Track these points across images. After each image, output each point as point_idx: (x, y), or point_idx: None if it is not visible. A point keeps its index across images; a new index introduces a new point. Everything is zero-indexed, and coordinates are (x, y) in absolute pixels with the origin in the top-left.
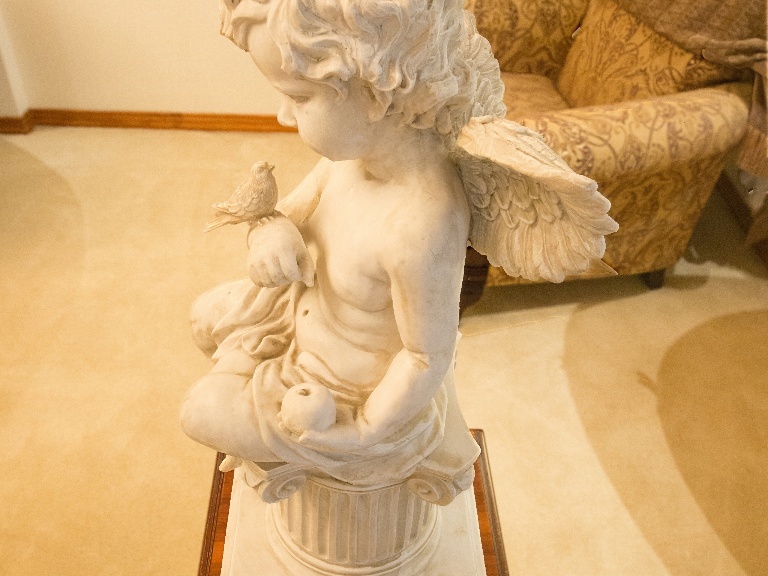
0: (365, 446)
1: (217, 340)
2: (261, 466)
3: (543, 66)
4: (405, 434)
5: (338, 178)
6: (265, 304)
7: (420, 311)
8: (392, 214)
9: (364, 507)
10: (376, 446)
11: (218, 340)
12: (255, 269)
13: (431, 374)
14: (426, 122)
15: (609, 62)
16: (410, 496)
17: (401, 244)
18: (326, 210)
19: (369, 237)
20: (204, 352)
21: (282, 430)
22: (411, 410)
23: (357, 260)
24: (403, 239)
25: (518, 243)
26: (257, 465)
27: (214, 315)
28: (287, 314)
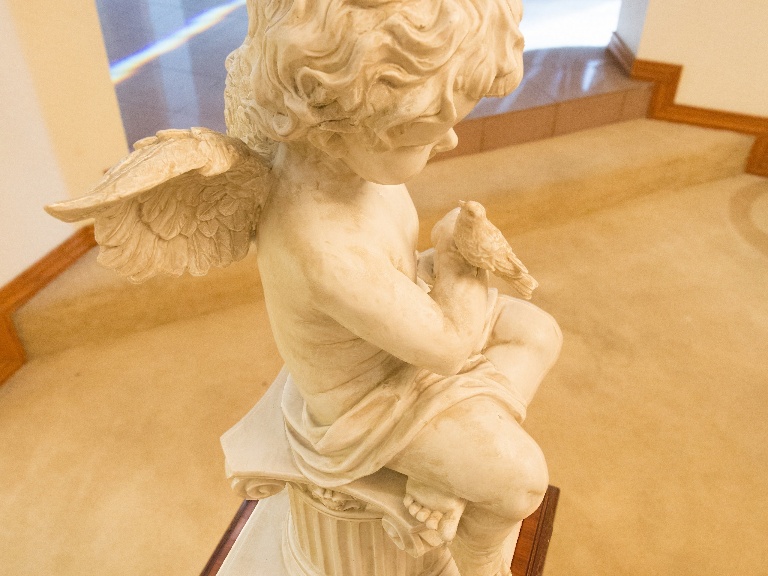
0: None
1: None
2: None
3: None
4: None
5: (383, 220)
6: None
7: None
8: None
9: None
10: None
11: None
12: None
13: None
14: None
15: None
16: None
17: None
18: None
19: None
20: None
21: None
22: None
23: None
24: None
25: None
26: None
27: None
28: None
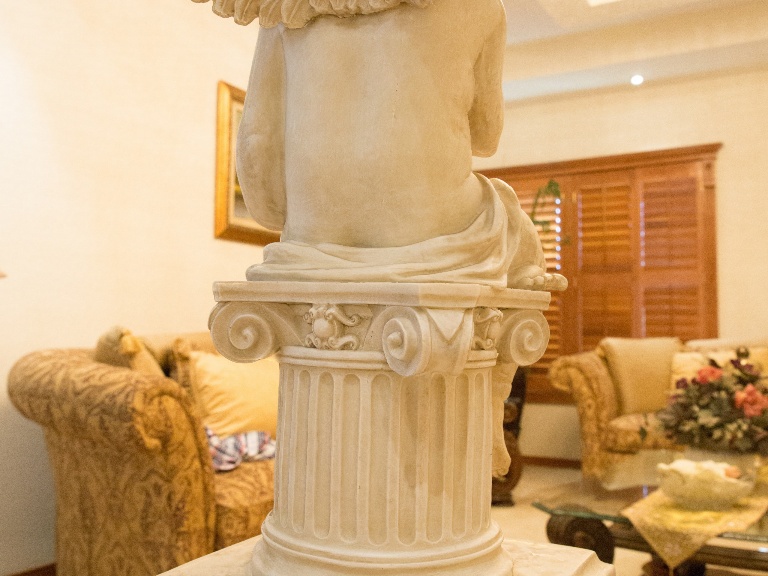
0: None
1: None
2: None
3: None
4: None
5: None
6: None
7: None
8: None
9: None
10: None
11: None
12: None
13: None
14: None
15: None
16: None
17: None
18: None
19: None
20: None
21: None
22: None
23: None
24: None
25: None
26: None
27: None
28: None
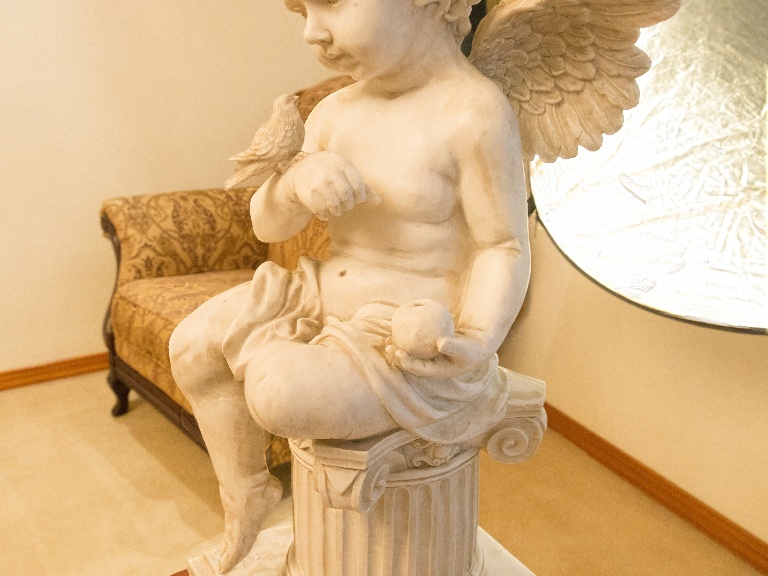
0: (488, 355)
1: (229, 353)
2: (357, 449)
3: (249, 261)
4: (485, 372)
5: (350, 117)
6: (279, 293)
7: (505, 189)
8: (451, 100)
9: (442, 503)
10: (469, 386)
11: (230, 353)
12: (319, 192)
13: (525, 260)
14: (458, 11)
15: (315, 236)
16: (475, 483)
17: (478, 116)
18: (351, 146)
19: (432, 130)
20: (199, 390)
21: (404, 357)
22: (517, 304)
23: (426, 157)
24: (478, 111)
25: (551, 124)
26: (352, 450)
27: (214, 329)
28: (306, 298)
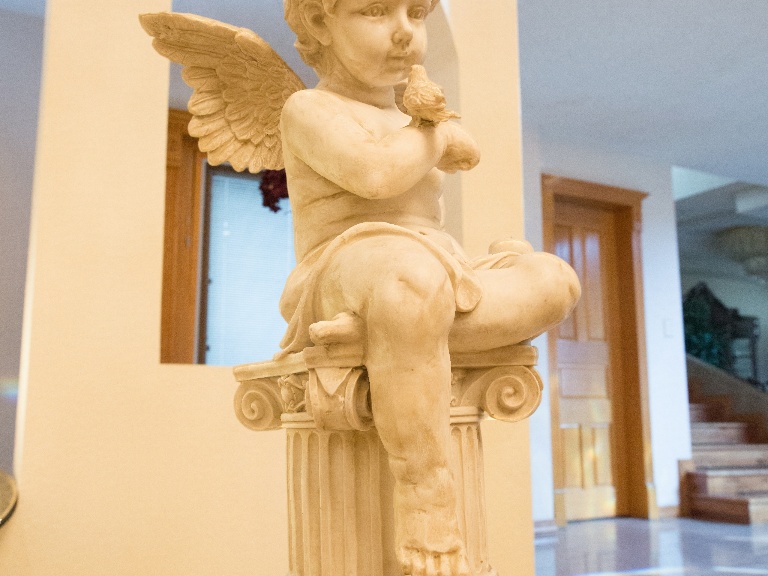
0: None
1: None
2: None
3: None
4: None
5: (369, 111)
6: None
7: None
8: None
9: None
10: None
11: None
12: None
13: None
14: None
15: None
16: None
17: None
18: (392, 131)
19: None
20: None
21: None
22: None
23: None
24: None
25: None
26: None
27: None
28: None
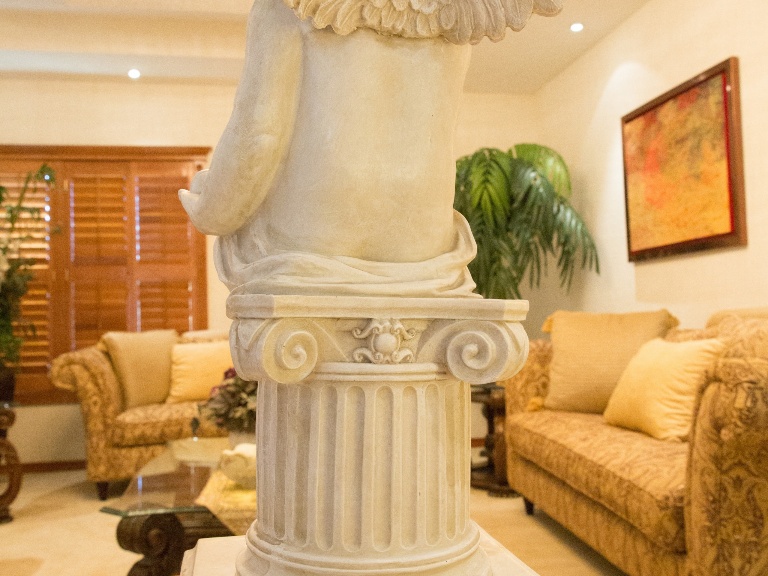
0: (194, 213)
1: None
2: None
3: None
4: None
5: None
6: None
7: None
8: None
9: None
10: (238, 263)
11: None
12: None
13: None
14: None
15: None
16: (289, 420)
17: None
18: None
19: None
20: None
21: None
22: None
23: None
24: None
25: None
26: None
27: None
28: None
